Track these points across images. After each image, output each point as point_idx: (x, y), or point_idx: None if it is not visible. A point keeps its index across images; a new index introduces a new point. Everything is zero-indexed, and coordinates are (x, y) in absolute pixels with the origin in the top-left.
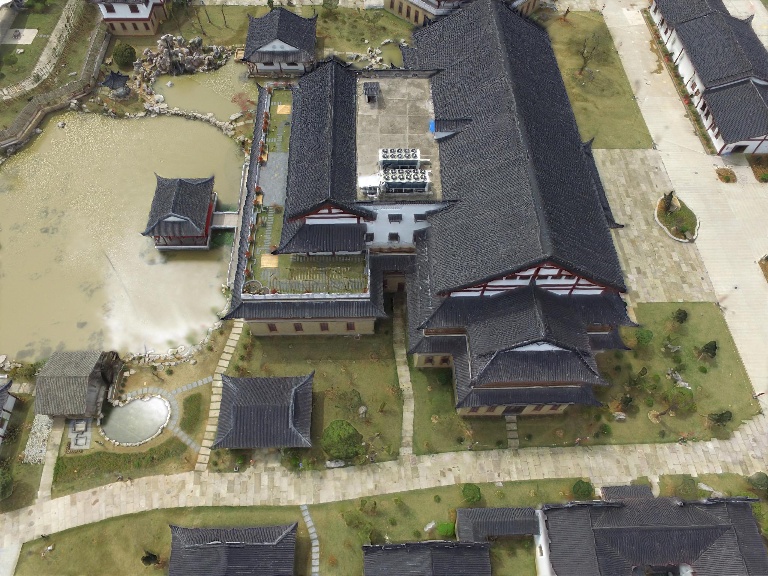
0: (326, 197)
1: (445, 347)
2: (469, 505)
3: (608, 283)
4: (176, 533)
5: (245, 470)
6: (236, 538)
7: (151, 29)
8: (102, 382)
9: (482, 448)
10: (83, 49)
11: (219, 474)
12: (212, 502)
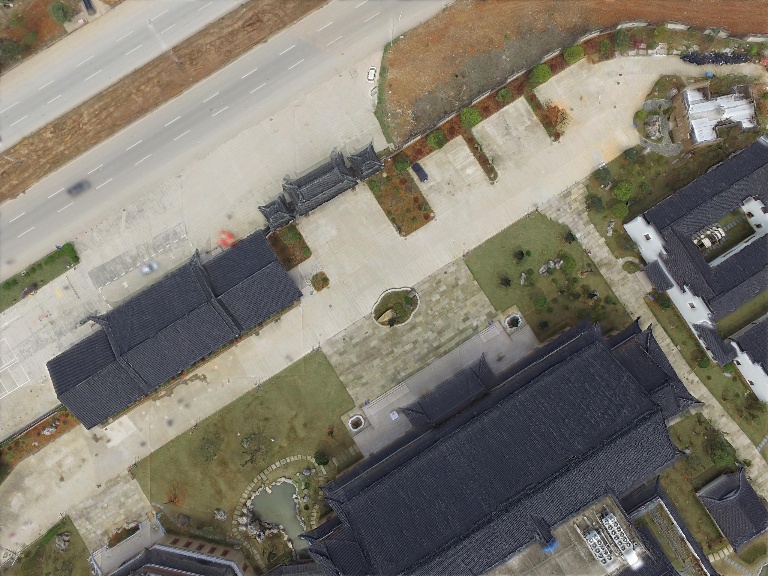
0: (671, 575)
1: None
2: None
3: None
4: None
5: (761, 496)
6: None
7: None
8: None
9: None
10: None
11: None
12: None
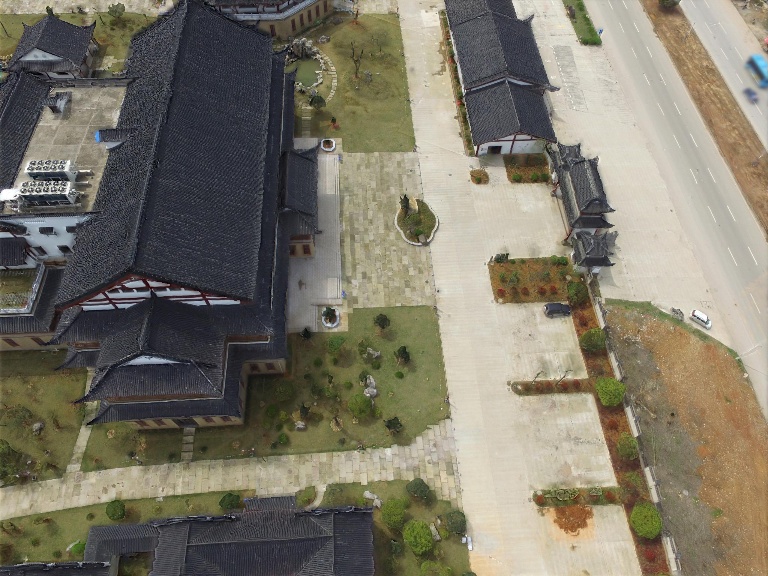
0: None
1: None
2: (119, 522)
3: (223, 293)
4: None
5: None
6: None
7: None
8: None
9: (153, 463)
10: None
11: None
12: None
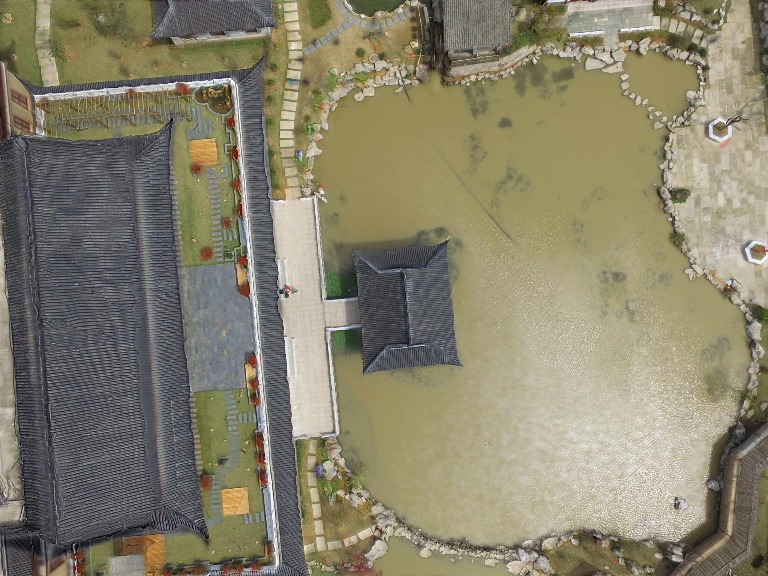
0: (24, 142)
1: None
2: None
3: None
4: None
5: None
6: None
7: None
8: None
9: None
10: None
11: None
12: None
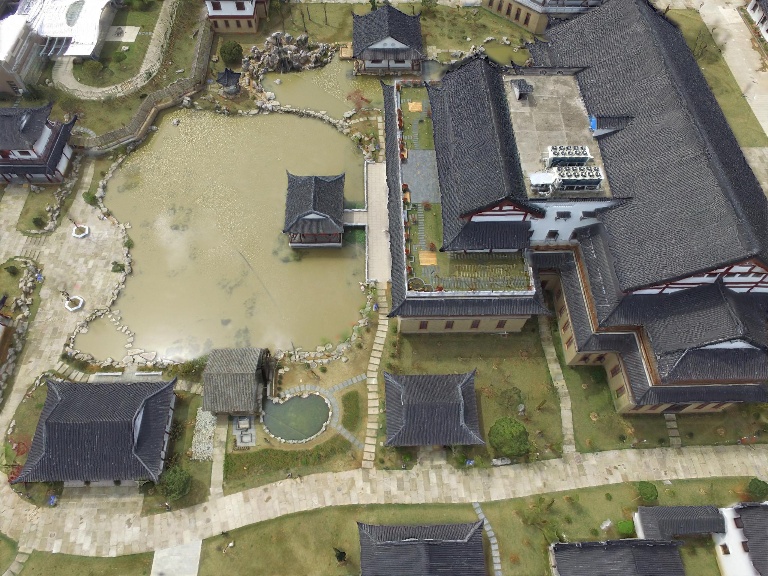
0: (505, 194)
1: (614, 345)
2: (642, 503)
3: None
4: (364, 530)
5: (412, 467)
6: (424, 535)
7: (254, 26)
8: (260, 379)
9: (645, 446)
10: (187, 46)
11: (387, 471)
12: (384, 499)
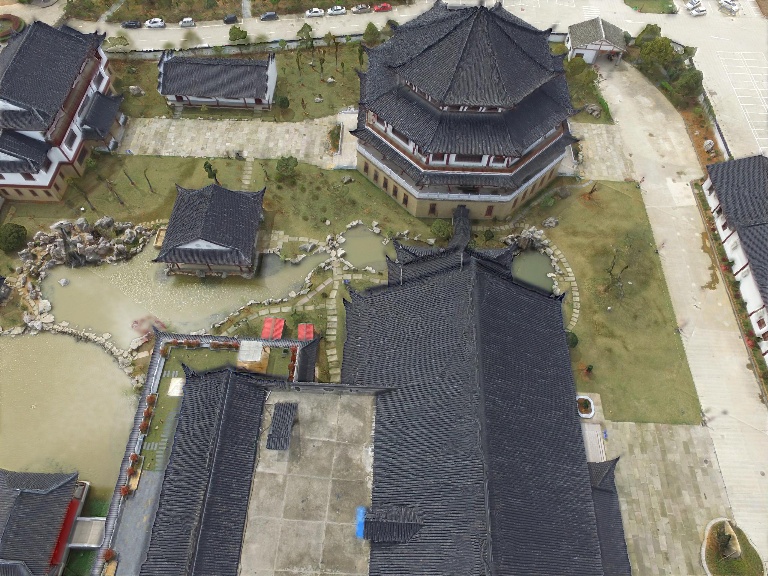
0: None
1: None
2: None
3: None
4: None
5: None
6: None
7: (54, 196)
8: None
9: None
10: None
11: None
12: None
